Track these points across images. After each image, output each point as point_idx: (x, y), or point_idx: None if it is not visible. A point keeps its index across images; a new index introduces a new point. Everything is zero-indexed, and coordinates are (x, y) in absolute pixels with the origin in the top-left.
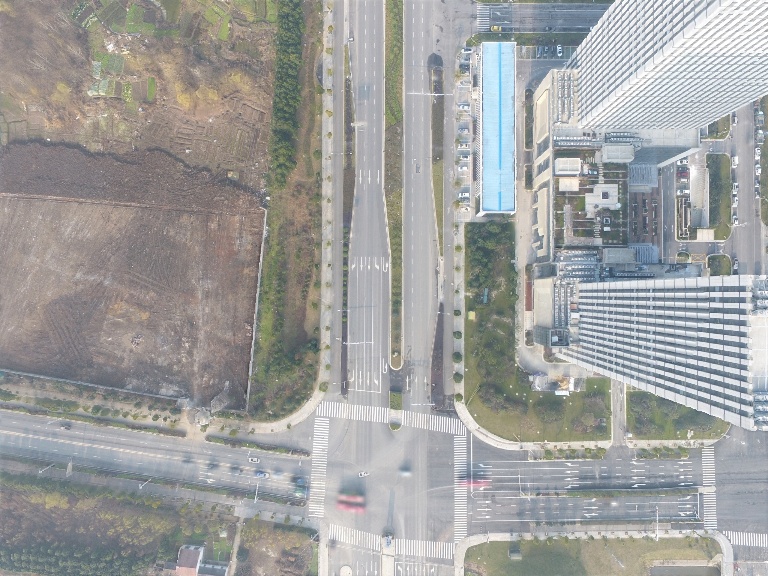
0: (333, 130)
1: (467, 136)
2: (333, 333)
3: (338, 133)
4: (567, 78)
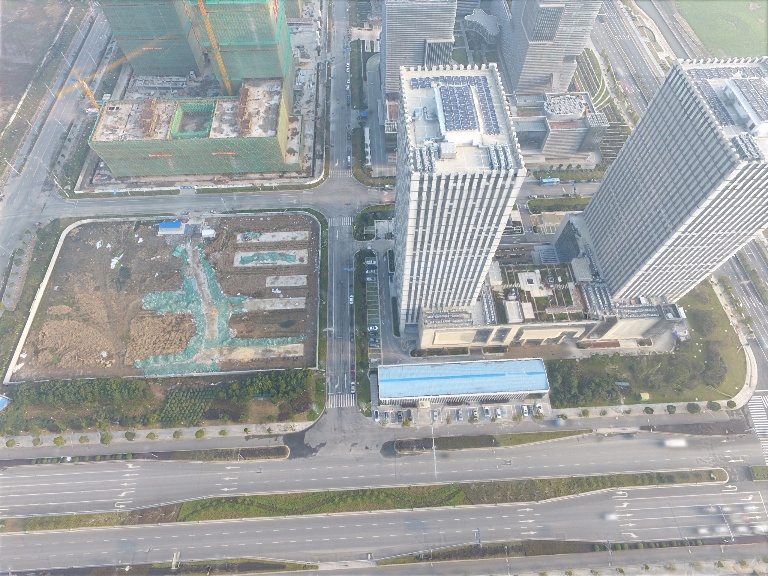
0: (480, 575)
1: (464, 411)
2: (718, 557)
3: (483, 567)
4: (432, 316)
